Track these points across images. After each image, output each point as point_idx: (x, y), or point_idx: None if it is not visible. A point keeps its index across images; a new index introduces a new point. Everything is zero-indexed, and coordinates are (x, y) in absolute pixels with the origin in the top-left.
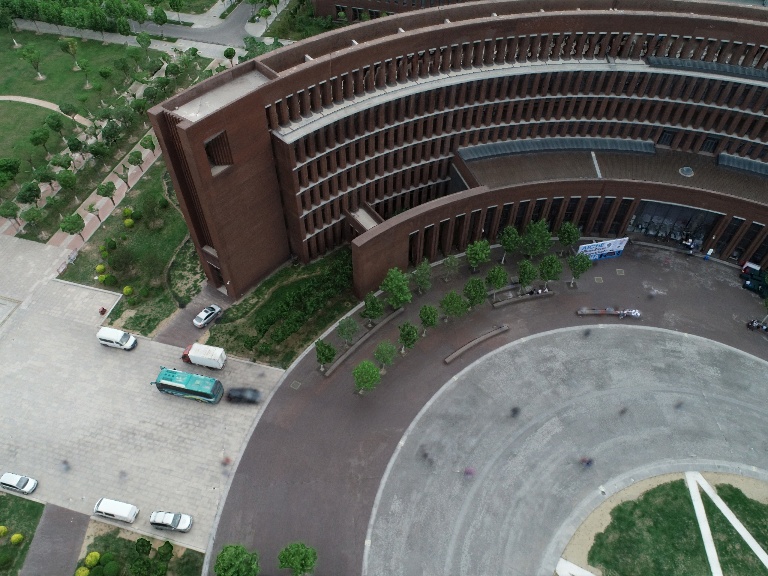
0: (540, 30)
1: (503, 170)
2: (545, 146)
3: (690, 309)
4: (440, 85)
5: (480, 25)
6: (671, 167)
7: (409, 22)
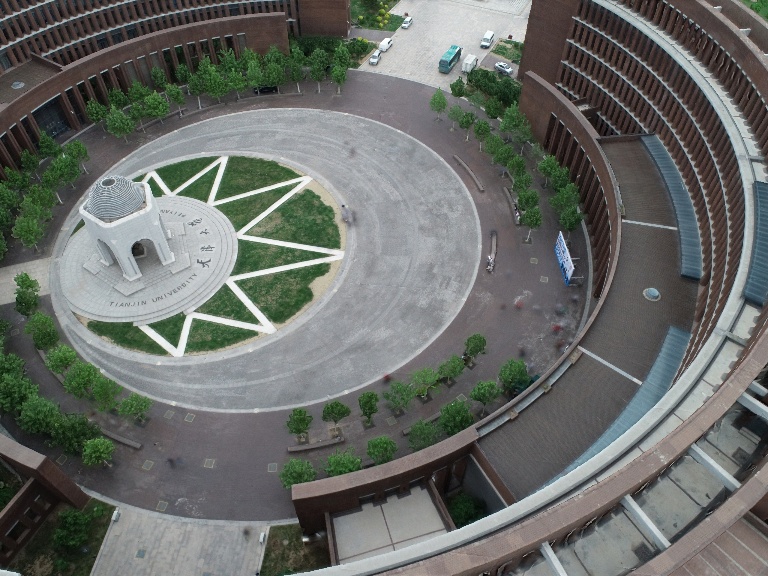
0: None
1: (633, 161)
2: (675, 191)
3: (494, 314)
4: (672, 54)
5: None
6: (660, 284)
7: (729, 7)
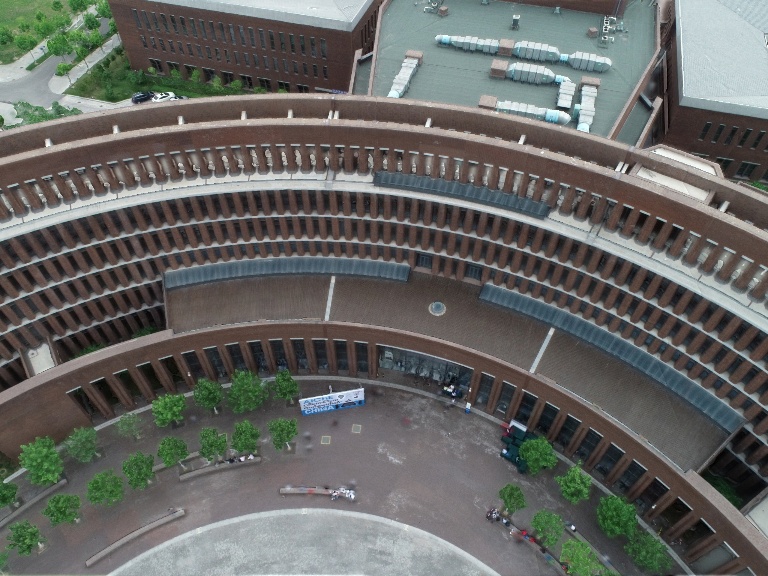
0: (227, 142)
1: (212, 302)
2: (275, 269)
3: (424, 487)
4: (97, 211)
5: (138, 139)
6: (421, 301)
7: (59, 131)
